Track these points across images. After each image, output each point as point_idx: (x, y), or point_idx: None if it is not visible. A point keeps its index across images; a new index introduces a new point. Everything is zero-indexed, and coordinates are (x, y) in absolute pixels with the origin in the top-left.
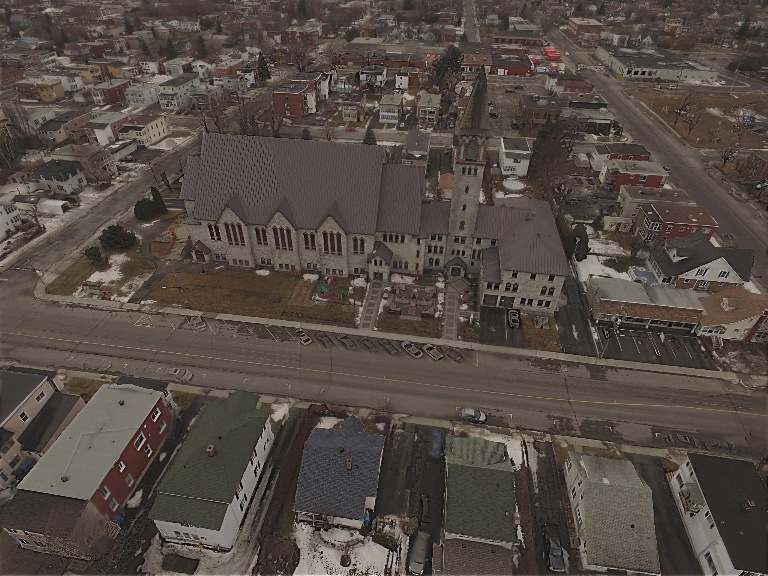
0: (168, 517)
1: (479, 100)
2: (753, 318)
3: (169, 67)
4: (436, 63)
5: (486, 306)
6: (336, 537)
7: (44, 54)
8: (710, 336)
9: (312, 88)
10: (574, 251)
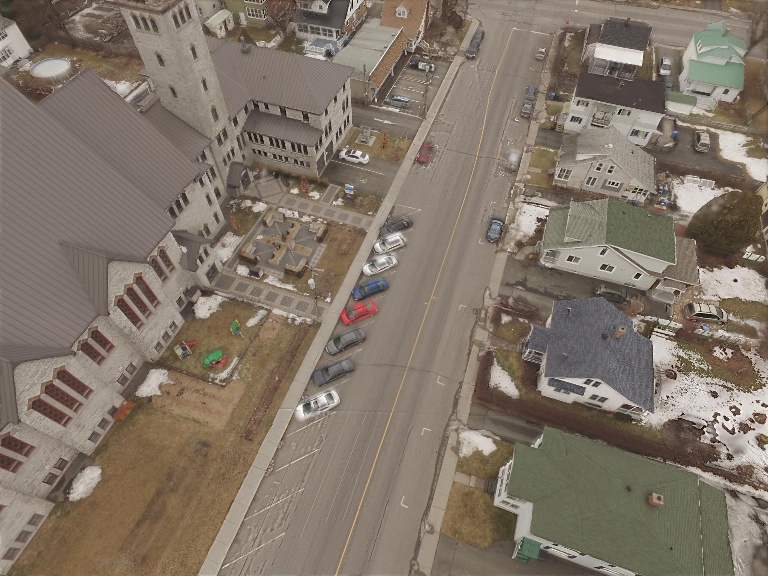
0: (730, 572)
1: None
2: None
3: None
4: None
5: (321, 175)
6: None
7: None
8: (417, 46)
9: None
10: None
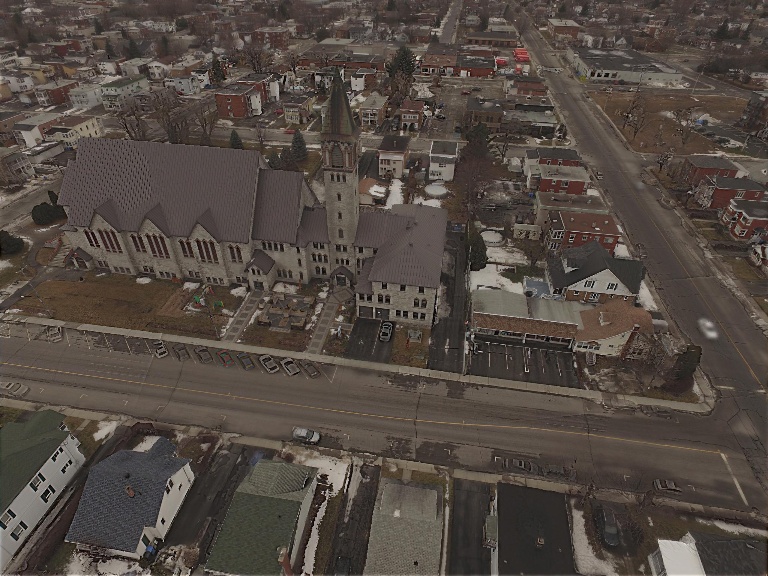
0: None
1: (336, 104)
2: (625, 334)
3: (124, 68)
4: (389, 64)
5: (363, 318)
6: (112, 569)
7: (3, 54)
8: (585, 352)
9: (260, 89)
10: (470, 260)
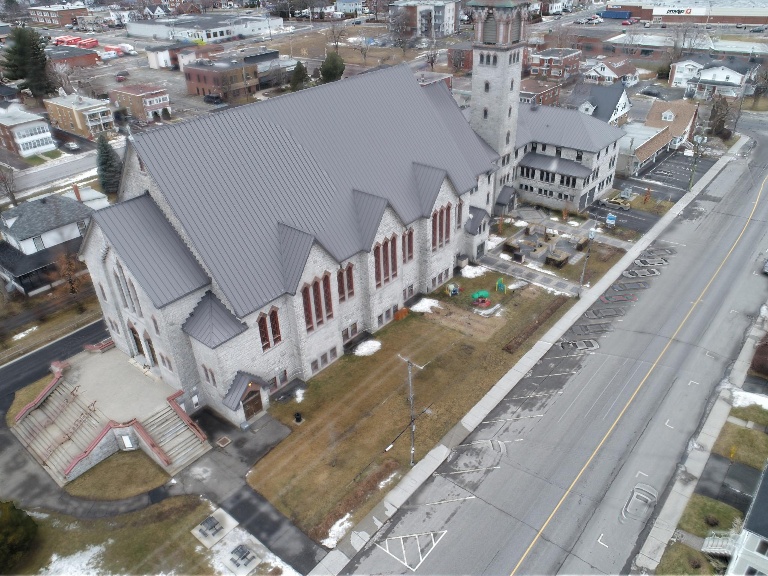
0: None
1: None
2: None
3: None
4: (3, 60)
5: (581, 212)
6: None
7: None
8: (681, 145)
9: None
10: None
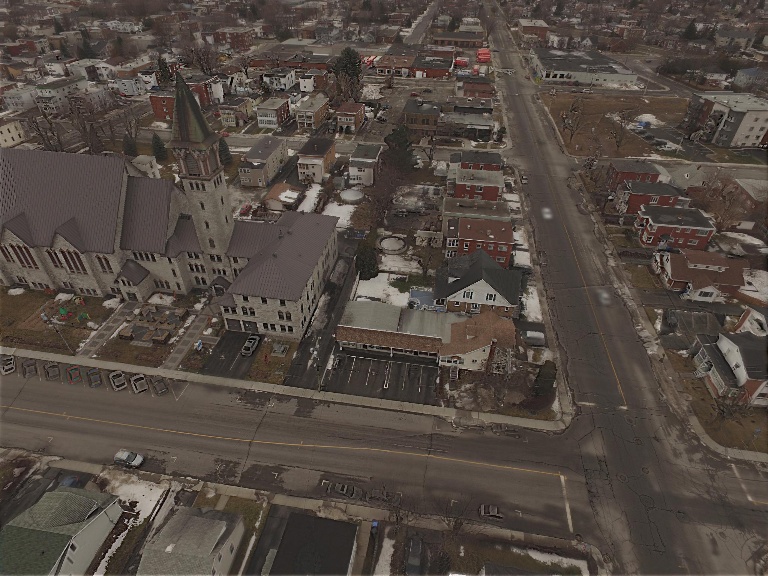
0: None
1: (182, 110)
2: (485, 348)
3: (71, 69)
4: (334, 66)
5: (232, 330)
6: None
7: None
8: (450, 366)
9: (201, 91)
10: (358, 269)
